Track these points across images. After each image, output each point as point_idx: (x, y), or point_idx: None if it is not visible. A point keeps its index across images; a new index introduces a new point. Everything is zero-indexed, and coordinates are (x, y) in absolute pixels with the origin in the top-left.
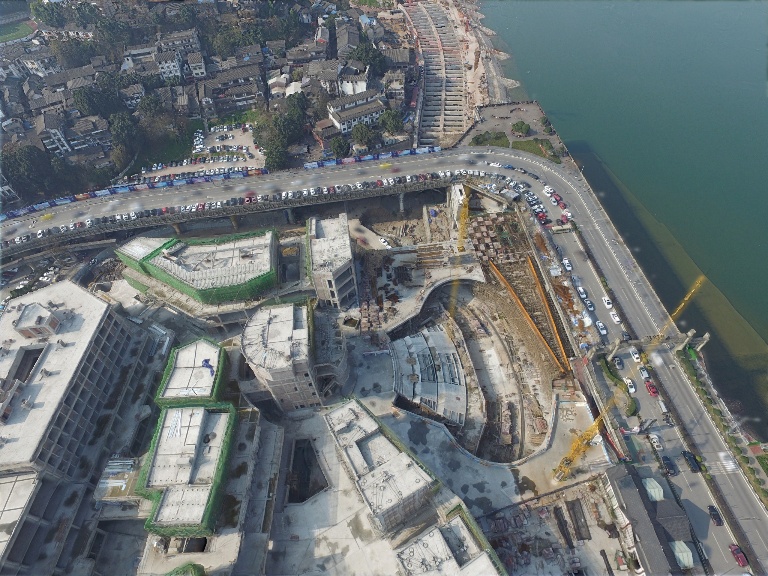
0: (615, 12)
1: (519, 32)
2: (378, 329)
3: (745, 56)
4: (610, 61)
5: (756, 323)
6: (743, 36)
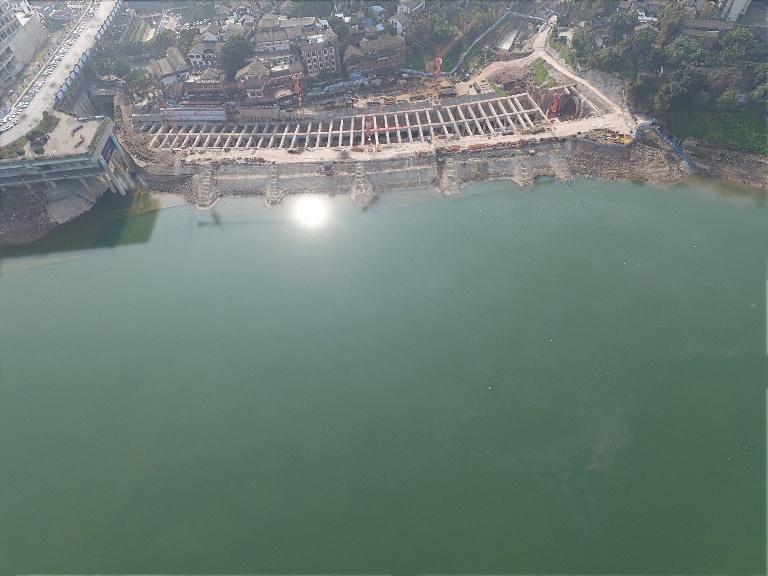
0: (551, 374)
1: (451, 219)
2: None
3: None
4: (320, 322)
5: None
6: None
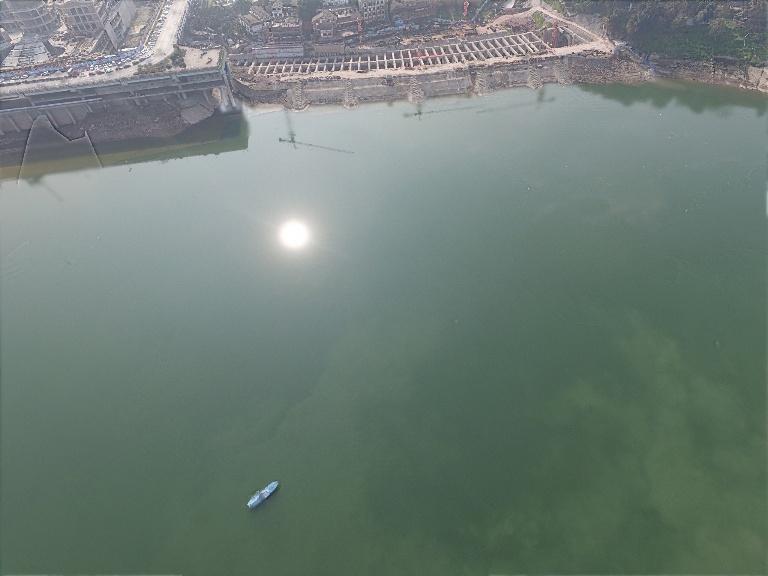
0: None
1: (486, 108)
2: (51, 38)
3: (422, 294)
4: (404, 165)
5: (7, 183)
6: (506, 313)
